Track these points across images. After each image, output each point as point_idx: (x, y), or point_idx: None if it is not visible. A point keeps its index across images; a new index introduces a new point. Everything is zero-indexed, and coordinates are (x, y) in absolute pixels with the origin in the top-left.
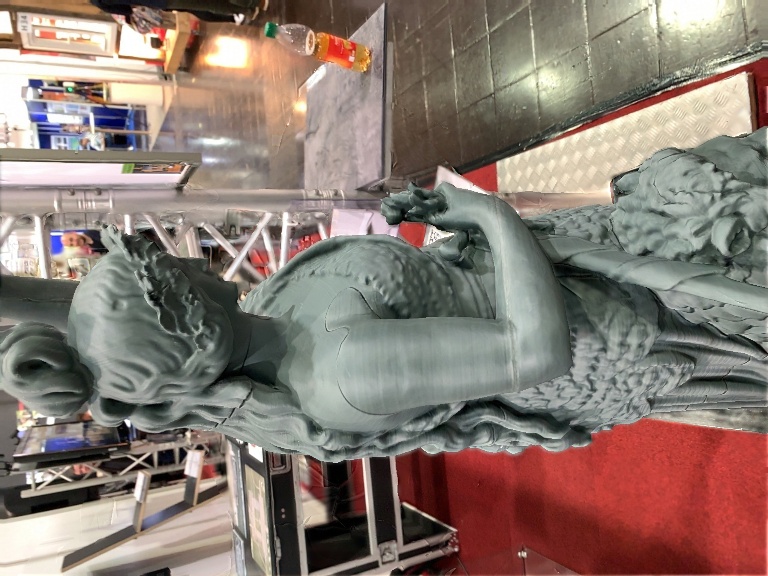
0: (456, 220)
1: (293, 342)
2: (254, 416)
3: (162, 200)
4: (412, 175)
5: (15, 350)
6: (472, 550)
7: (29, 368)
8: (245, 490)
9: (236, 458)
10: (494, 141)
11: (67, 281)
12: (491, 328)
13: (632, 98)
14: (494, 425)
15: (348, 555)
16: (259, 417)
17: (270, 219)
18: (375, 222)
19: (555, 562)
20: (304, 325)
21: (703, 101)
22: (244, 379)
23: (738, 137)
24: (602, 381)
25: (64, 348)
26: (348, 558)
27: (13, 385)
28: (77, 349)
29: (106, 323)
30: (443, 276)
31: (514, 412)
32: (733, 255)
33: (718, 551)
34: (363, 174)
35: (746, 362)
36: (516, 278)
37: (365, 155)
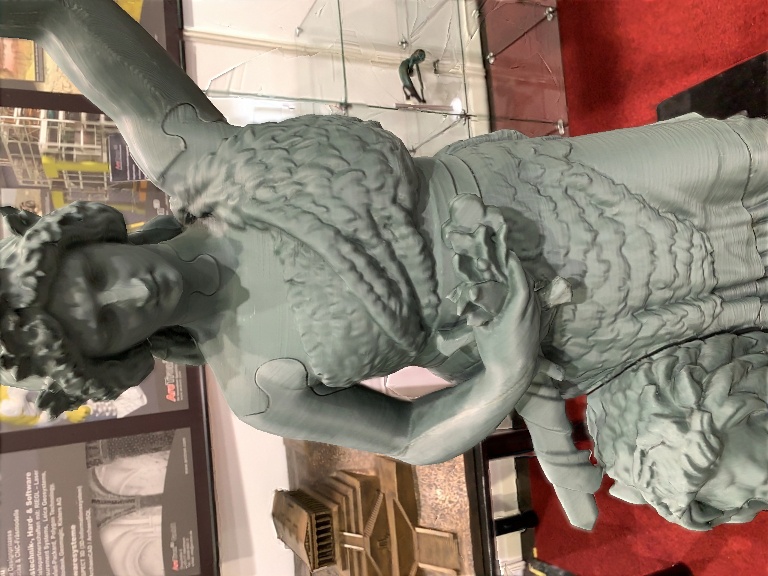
0: (477, 343)
1: (225, 339)
2: None
3: None
4: None
5: None
6: None
7: None
8: None
9: None
10: None
11: None
12: None
13: None
14: None
15: None
16: None
17: None
18: None
19: None
20: (241, 344)
21: None
22: (161, 347)
23: None
24: None
25: None
26: None
27: None
28: None
29: None
30: None
31: None
32: None
33: (635, 106)
34: None
35: None
36: (445, 439)
37: None
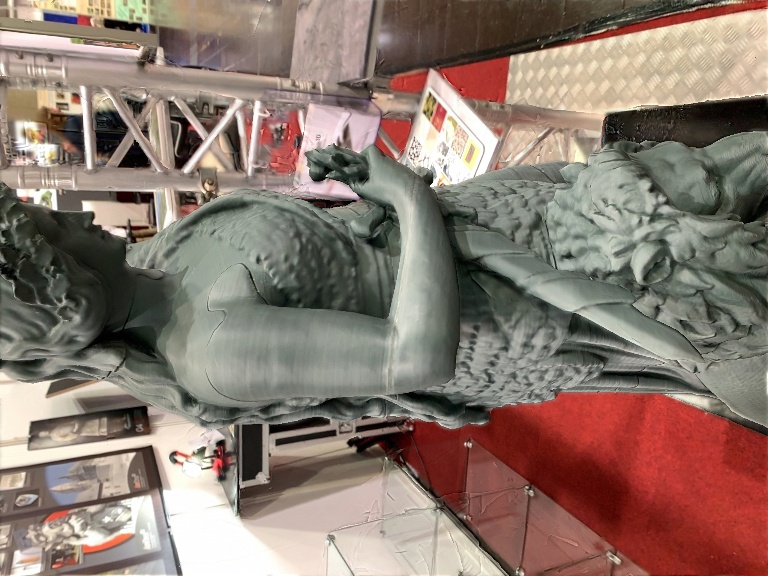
0: (373, 195)
1: (177, 311)
2: (131, 380)
3: (121, 74)
4: (401, 74)
5: None
6: (425, 432)
7: None
8: None
9: None
10: (513, 31)
11: None
12: (374, 332)
13: (665, 9)
14: (387, 401)
15: (310, 420)
16: (136, 381)
17: (240, 106)
18: (352, 123)
19: (495, 457)
20: (189, 295)
21: (737, 29)
22: (119, 346)
23: (741, 99)
24: (501, 375)
25: None
26: (309, 423)
27: None
28: None
29: None
30: (348, 256)
31: (408, 393)
32: (648, 284)
33: (639, 476)
34: (346, 68)
35: (661, 364)
36: (412, 280)
37: (350, 47)
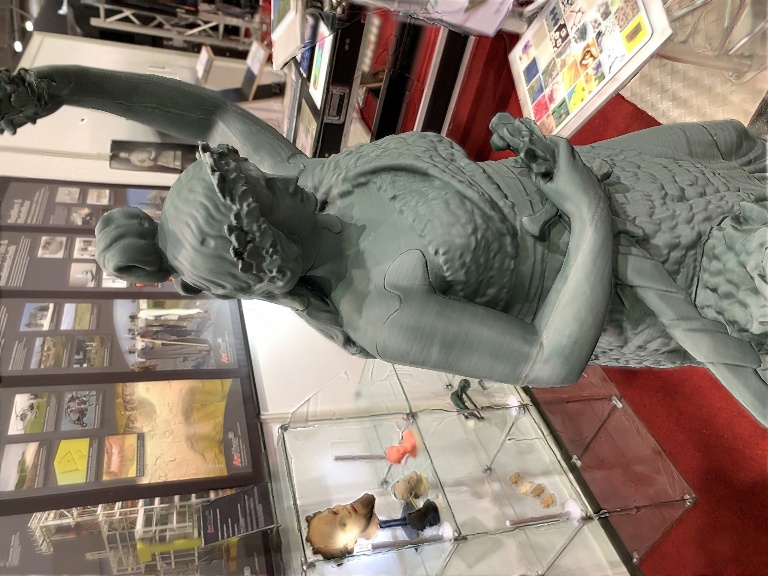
0: (552, 199)
1: (353, 272)
2: None
3: None
4: None
5: (116, 256)
6: None
7: (126, 267)
8: (297, 121)
9: (296, 85)
10: None
11: (159, 81)
12: (523, 342)
13: None
14: None
15: None
16: None
17: None
18: None
19: None
20: (367, 263)
21: None
22: (303, 294)
23: None
24: (607, 358)
25: (156, 250)
26: None
27: (113, 275)
28: (167, 256)
29: (194, 253)
30: (512, 251)
31: None
32: None
33: None
34: None
35: None
36: (569, 306)
37: None
